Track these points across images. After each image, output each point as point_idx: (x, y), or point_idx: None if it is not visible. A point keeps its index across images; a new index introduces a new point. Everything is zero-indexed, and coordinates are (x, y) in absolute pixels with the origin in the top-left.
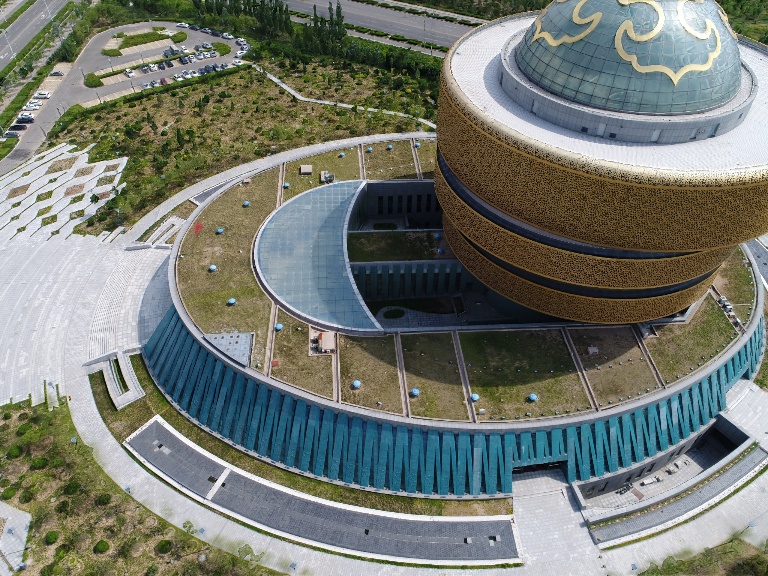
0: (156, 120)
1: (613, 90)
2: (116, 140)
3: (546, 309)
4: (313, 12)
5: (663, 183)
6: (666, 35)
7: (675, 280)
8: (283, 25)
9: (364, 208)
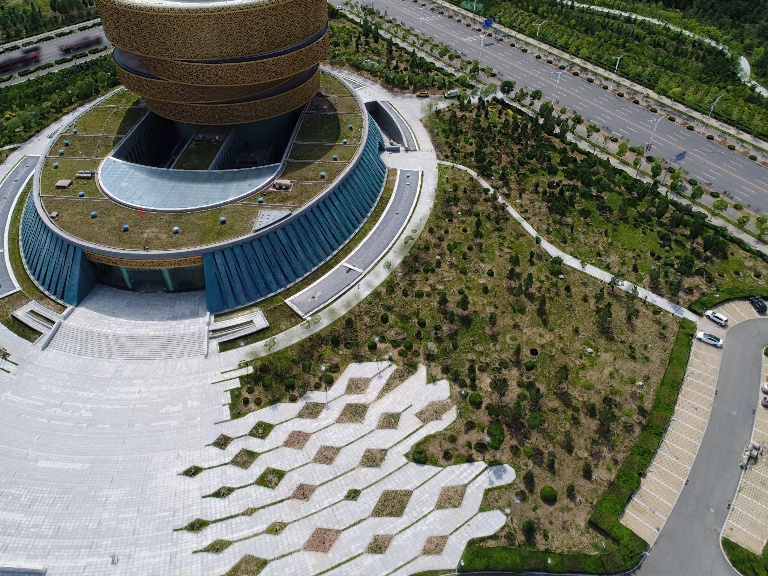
0: None
1: None
2: None
3: (301, 102)
4: None
5: None
6: None
7: None
8: None
9: None
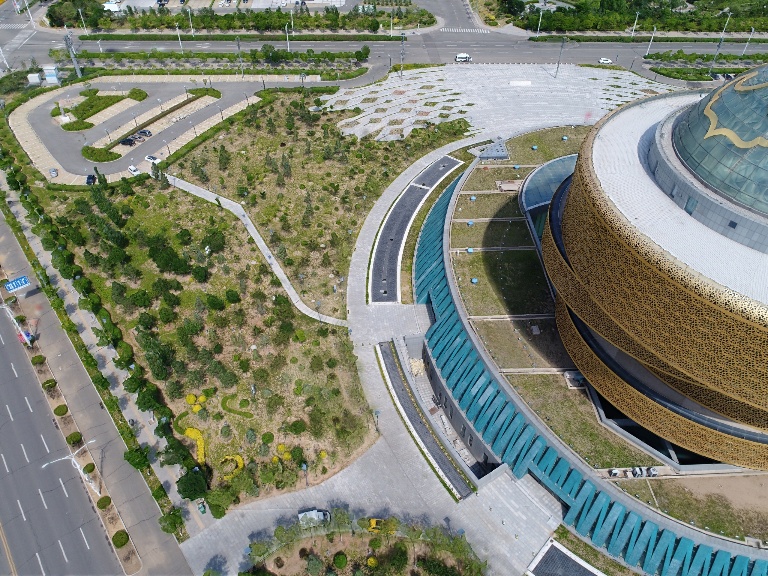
0: None
1: None
2: None
3: None
4: None
5: (579, 167)
6: (752, 96)
7: None
8: None
9: None
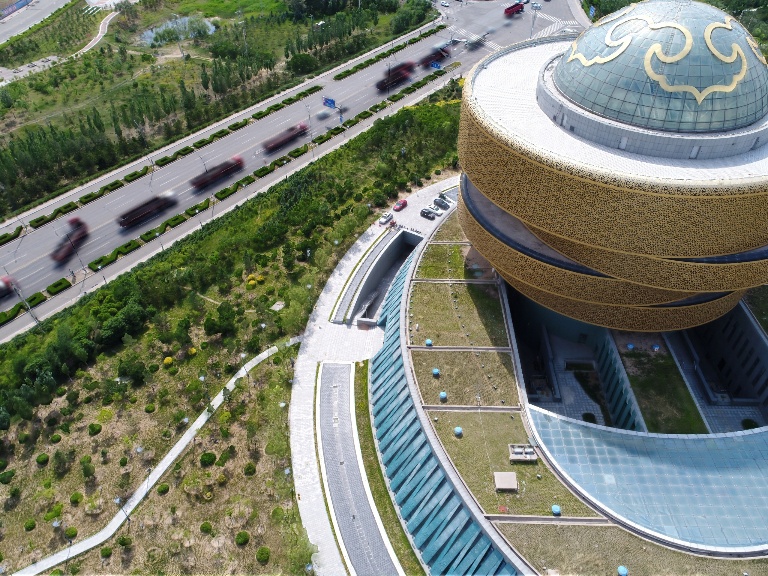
0: None
1: None
2: None
3: None
4: None
5: None
6: None
7: None
8: None
9: None
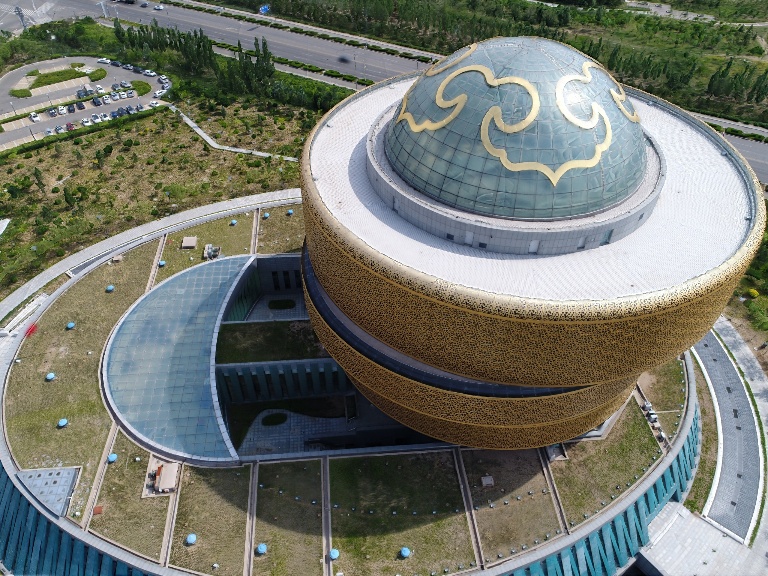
0: (51, 173)
1: (481, 191)
2: (2, 198)
3: (431, 432)
4: (247, 45)
5: (533, 317)
6: (541, 125)
7: (569, 414)
8: (208, 61)
9: (256, 285)
